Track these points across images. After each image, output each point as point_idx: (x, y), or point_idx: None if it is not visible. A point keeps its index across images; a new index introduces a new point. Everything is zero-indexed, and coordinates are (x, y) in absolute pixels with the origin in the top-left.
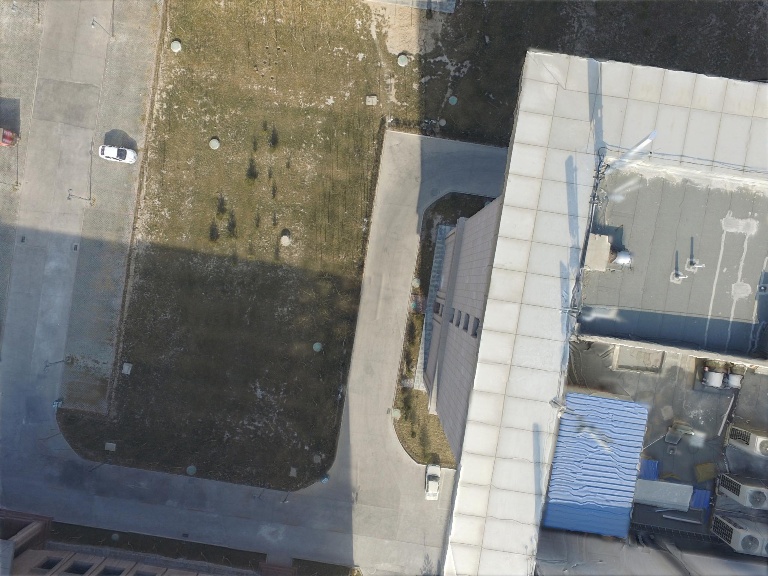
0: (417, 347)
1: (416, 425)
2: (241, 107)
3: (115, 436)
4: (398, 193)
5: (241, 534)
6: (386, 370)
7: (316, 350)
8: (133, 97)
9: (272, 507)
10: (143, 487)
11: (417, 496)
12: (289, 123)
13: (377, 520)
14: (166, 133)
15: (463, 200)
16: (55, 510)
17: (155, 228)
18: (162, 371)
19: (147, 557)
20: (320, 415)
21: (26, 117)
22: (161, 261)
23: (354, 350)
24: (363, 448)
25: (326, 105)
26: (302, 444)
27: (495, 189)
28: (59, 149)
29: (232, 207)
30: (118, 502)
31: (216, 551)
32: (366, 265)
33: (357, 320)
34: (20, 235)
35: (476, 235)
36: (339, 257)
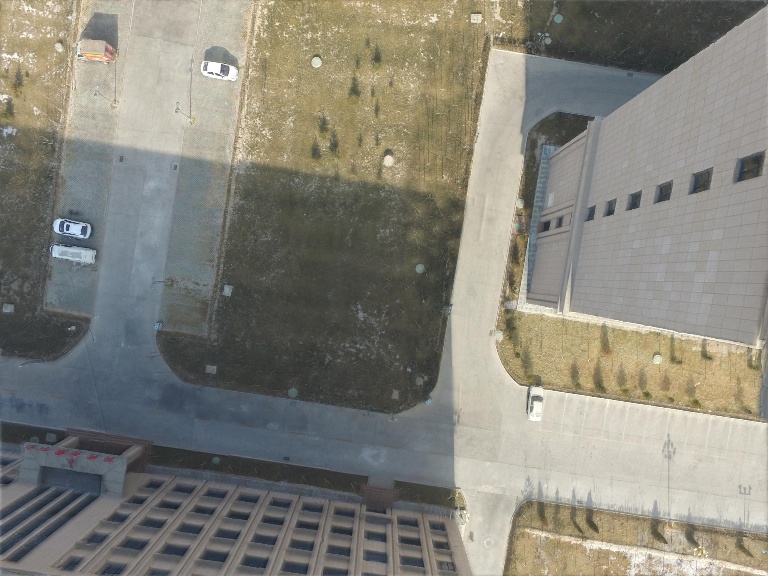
0: (520, 268)
1: (518, 347)
2: (344, 24)
3: (215, 359)
4: (502, 113)
5: (342, 457)
6: (489, 292)
7: (419, 272)
8: (234, 13)
9: (374, 429)
10: (244, 410)
11: (519, 418)
12: (392, 41)
13: (479, 442)
14: (267, 51)
15: (567, 120)
16: (154, 434)
17: (256, 148)
18: (263, 293)
19: (248, 480)
20: (422, 337)
21: (124, 33)
22: (262, 182)
23: (457, 271)
24: (465, 370)
25: (430, 23)
26: (404, 366)
27: (600, 109)
28: (158, 66)
29: (334, 127)
30: (218, 425)
31: (317, 474)
32: (470, 186)
33: (460, 241)
34: (118, 154)
35: (639, 116)
36: (442, 178)
